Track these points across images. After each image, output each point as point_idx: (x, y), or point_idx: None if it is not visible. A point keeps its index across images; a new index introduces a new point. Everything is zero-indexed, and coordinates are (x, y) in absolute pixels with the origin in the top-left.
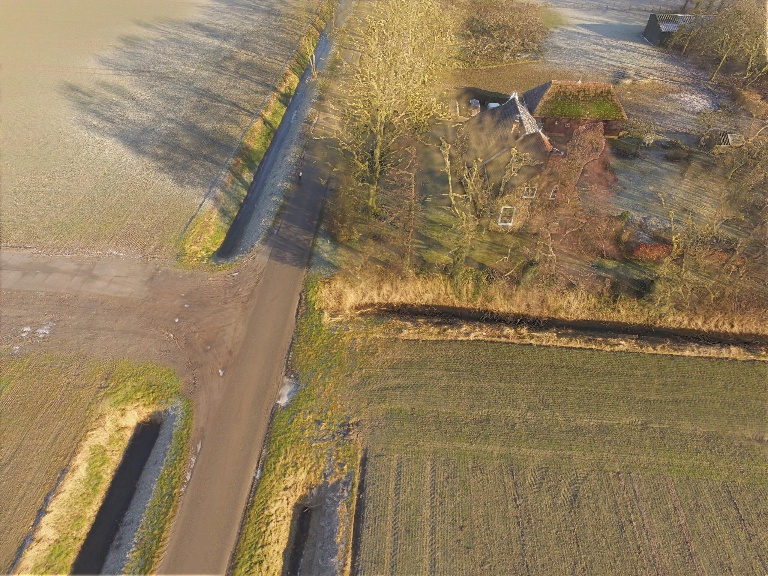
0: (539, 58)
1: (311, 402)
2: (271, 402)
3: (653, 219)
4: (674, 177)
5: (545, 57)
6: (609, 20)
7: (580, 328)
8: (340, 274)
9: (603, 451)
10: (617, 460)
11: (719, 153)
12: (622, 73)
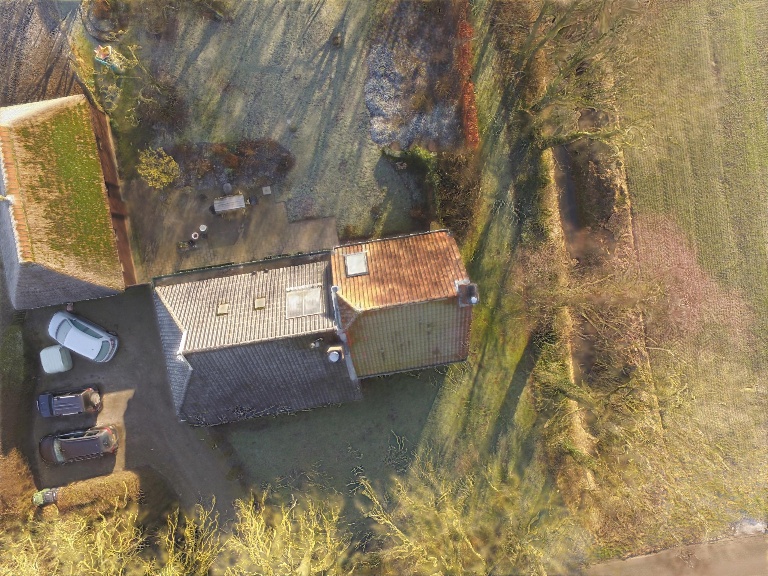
0: None
1: (761, 502)
2: (765, 538)
3: (377, 102)
4: (229, 37)
5: None
6: None
7: (575, 224)
8: (583, 524)
9: (761, 225)
10: (766, 213)
11: None
12: None
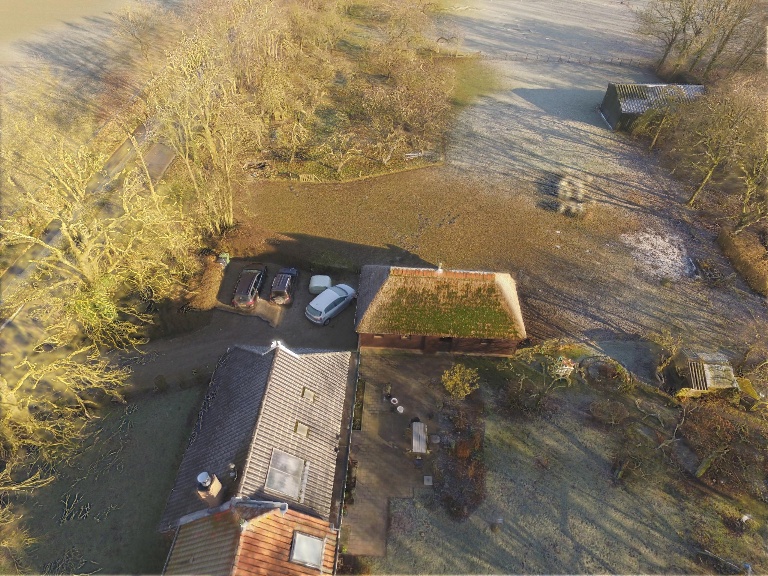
0: (438, 158)
1: None
2: None
3: None
4: (597, 480)
5: (448, 156)
6: (558, 81)
7: None
8: None
9: None
10: None
11: (689, 397)
12: (555, 188)
